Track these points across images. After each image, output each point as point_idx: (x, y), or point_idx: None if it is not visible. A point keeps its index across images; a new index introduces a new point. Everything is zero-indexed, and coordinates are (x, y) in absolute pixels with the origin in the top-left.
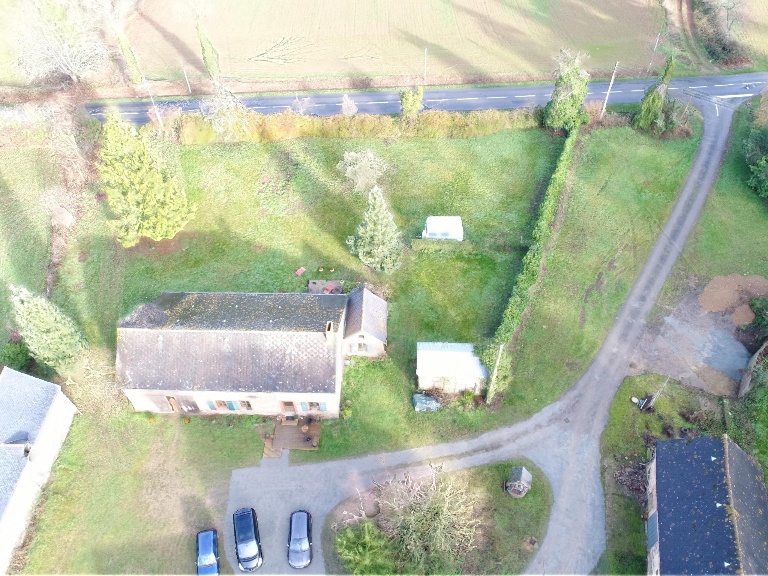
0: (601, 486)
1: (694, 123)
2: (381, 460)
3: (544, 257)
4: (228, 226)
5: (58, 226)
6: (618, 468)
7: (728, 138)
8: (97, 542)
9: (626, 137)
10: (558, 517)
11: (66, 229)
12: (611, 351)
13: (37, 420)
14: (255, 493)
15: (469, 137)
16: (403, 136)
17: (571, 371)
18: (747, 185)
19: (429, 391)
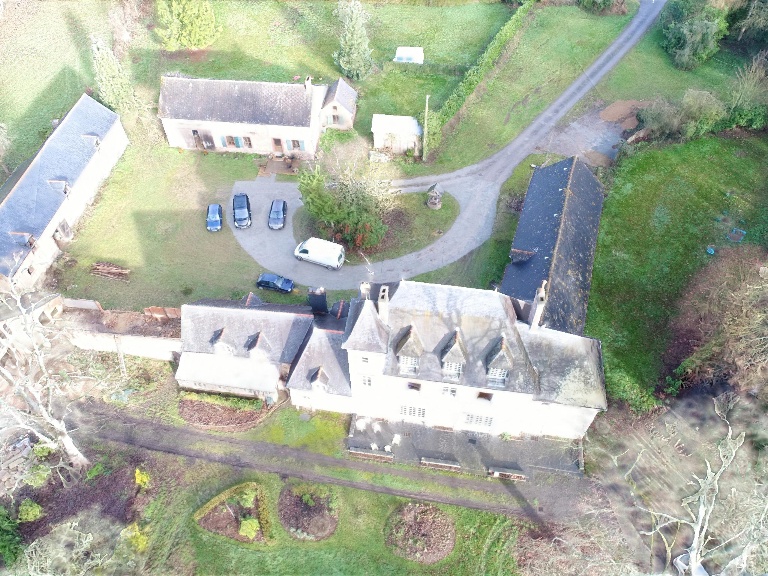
0: (496, 208)
1: (631, 6)
2: (334, 151)
3: (485, 82)
4: (245, 49)
5: (118, 40)
6: (510, 200)
7: (656, 17)
8: (141, 208)
9: (572, 13)
10: (461, 221)
11: (124, 43)
12: (524, 139)
13: (104, 129)
14: (250, 193)
15: (443, 6)
16: (390, 3)
17: (490, 148)
18: (661, 46)
19: (381, 149)
